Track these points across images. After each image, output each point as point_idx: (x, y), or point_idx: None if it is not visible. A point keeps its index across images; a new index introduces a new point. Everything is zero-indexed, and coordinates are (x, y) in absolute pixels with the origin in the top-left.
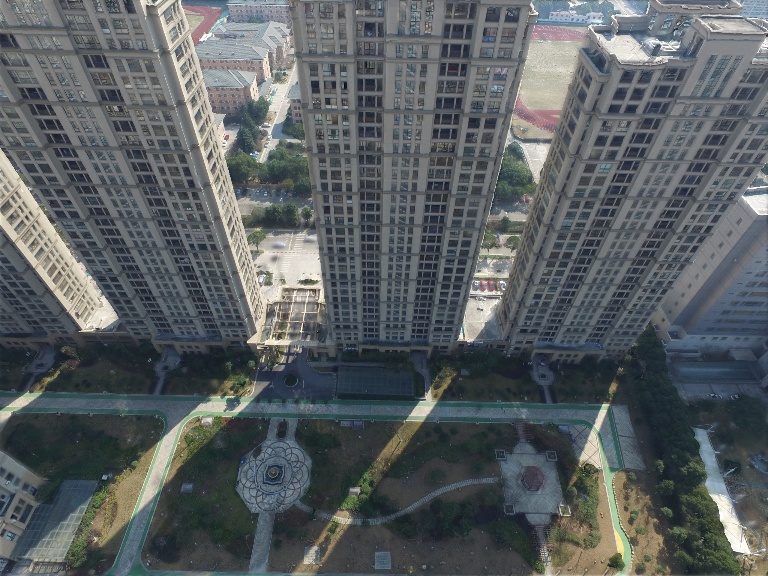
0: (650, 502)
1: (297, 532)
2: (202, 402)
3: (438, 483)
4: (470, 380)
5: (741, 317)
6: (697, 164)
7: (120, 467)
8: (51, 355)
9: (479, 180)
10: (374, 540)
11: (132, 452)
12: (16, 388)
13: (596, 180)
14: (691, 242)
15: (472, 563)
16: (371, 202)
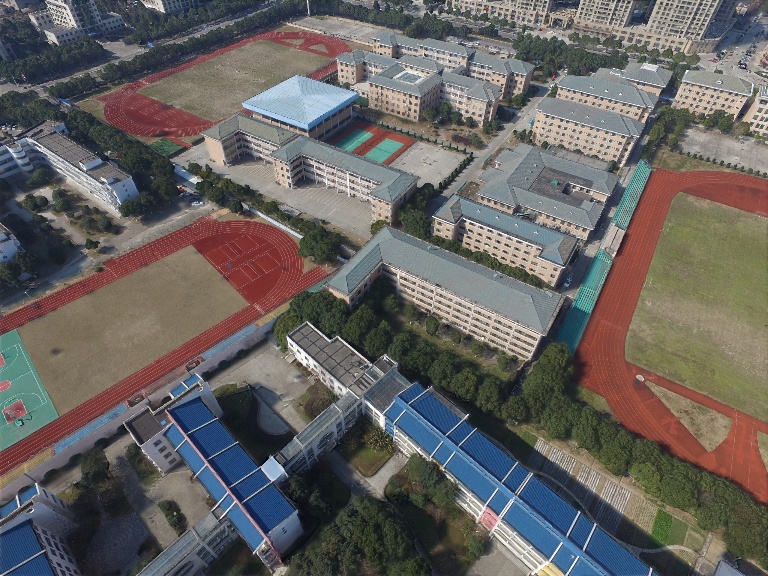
0: None
1: (573, 3)
2: None
3: None
4: None
5: None
6: None
7: None
8: None
9: None
10: None
11: None
12: None
13: None
14: None
15: None
16: None
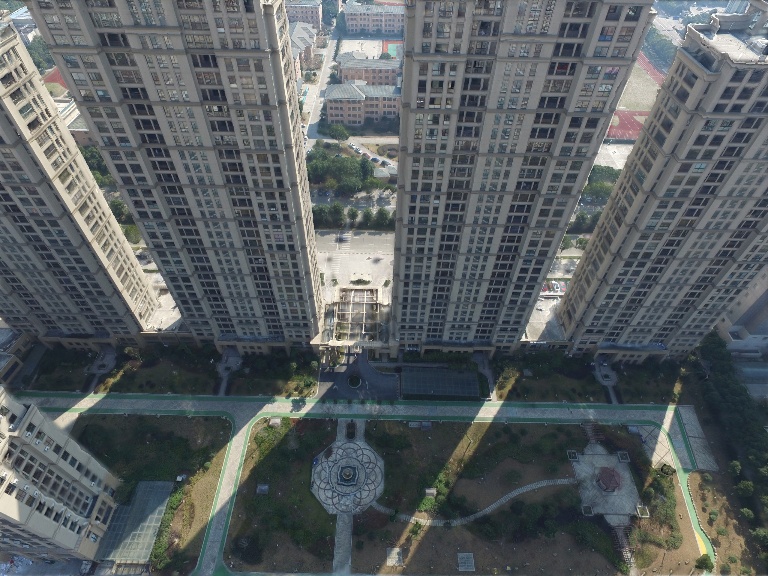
0: (727, 503)
1: (378, 533)
2: (268, 403)
3: (514, 484)
4: (534, 381)
5: None
6: None
7: (194, 468)
8: (112, 356)
9: (571, 180)
10: (455, 541)
11: (204, 453)
12: (80, 389)
13: (689, 180)
14: None
15: (556, 564)
16: (457, 202)
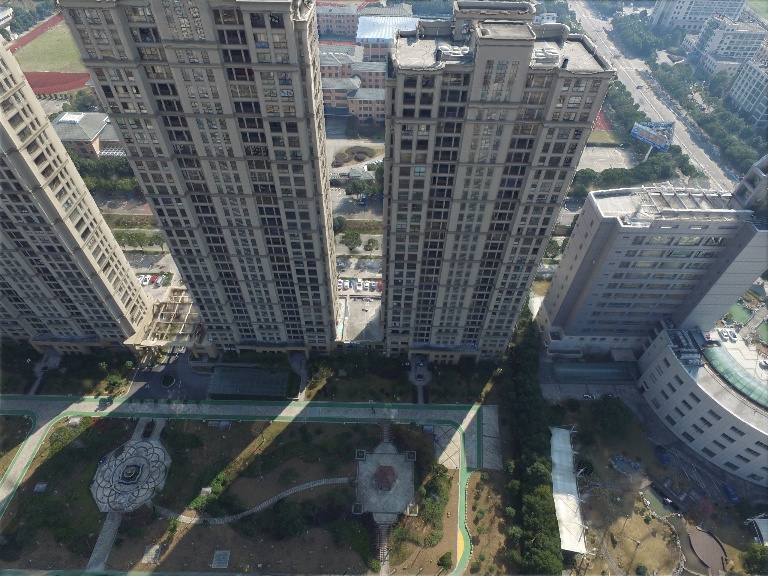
0: (500, 502)
1: (140, 531)
2: (75, 402)
3: (291, 483)
4: (346, 380)
5: (613, 318)
6: (512, 167)
7: None
8: None
9: (300, 183)
10: (216, 539)
11: None
12: None
13: (415, 183)
14: (530, 244)
15: (309, 562)
16: (204, 204)
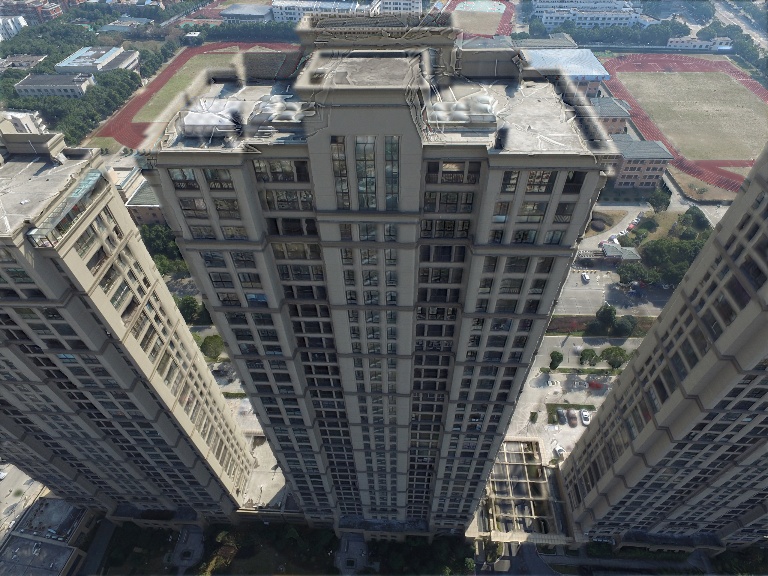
0: None
1: None
2: None
3: None
4: None
5: None
6: None
7: None
8: (197, 536)
9: None
10: None
11: None
12: None
13: None
14: None
15: None
16: None
